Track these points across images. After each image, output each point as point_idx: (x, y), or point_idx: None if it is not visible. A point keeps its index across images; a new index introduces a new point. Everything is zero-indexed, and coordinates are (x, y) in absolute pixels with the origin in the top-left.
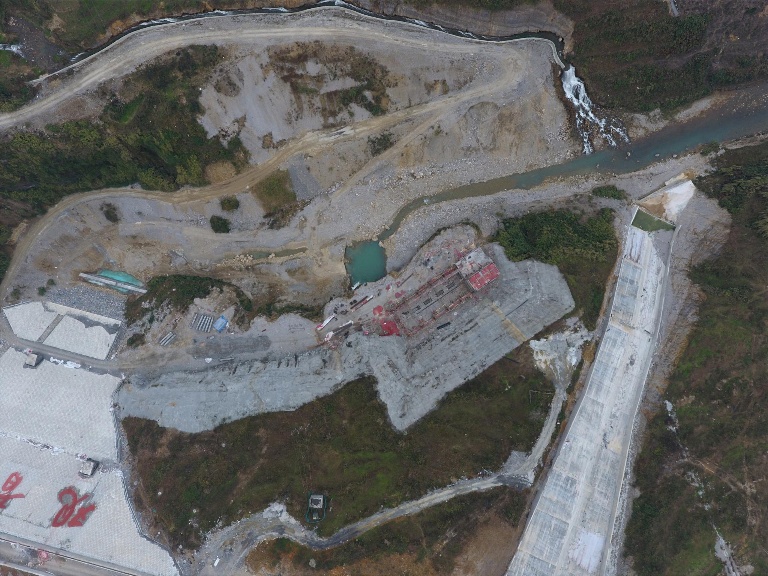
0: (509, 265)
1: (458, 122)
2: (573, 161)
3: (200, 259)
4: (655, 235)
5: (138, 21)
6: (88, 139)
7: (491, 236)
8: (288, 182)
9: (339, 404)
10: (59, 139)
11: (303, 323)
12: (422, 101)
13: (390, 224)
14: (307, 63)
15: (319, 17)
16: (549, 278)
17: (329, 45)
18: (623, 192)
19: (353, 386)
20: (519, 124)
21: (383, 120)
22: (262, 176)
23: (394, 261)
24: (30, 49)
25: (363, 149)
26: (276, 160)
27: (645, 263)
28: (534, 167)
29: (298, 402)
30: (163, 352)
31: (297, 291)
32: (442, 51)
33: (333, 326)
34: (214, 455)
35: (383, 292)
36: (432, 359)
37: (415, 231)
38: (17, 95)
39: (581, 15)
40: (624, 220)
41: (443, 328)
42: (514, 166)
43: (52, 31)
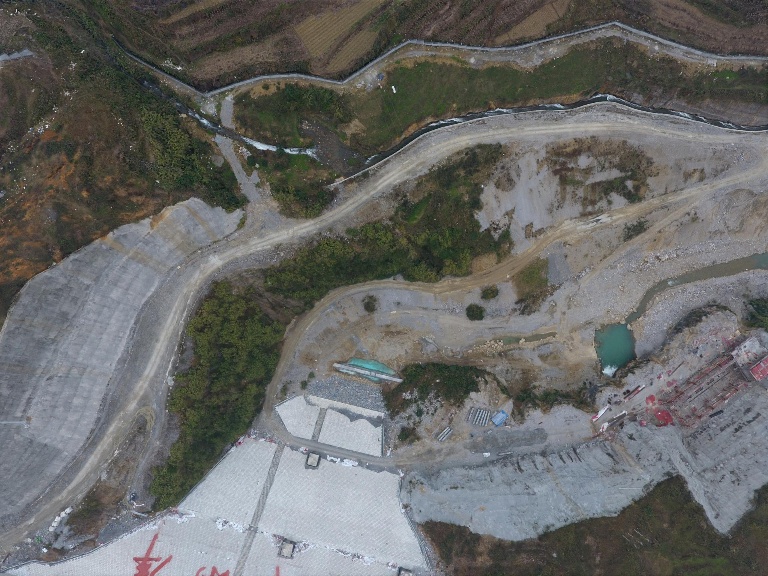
0: None
1: (713, 208)
2: None
3: (451, 346)
4: None
5: (428, 122)
6: (384, 241)
7: (745, 319)
8: (544, 269)
9: (655, 507)
10: (357, 242)
11: (578, 414)
12: (678, 188)
13: (637, 307)
14: (580, 157)
15: (594, 113)
16: None
17: (604, 140)
18: None
19: (665, 487)
20: None
21: (639, 207)
22: (522, 265)
23: (644, 344)
24: (325, 152)
25: (618, 235)
26: (535, 249)
27: None
28: None
29: (616, 506)
30: (440, 447)
31: (550, 376)
32: (706, 142)
33: (608, 417)
34: (547, 566)
35: (655, 381)
36: (720, 452)
37: (663, 314)
38: (313, 199)
39: None
40: None
41: (716, 416)
42: (755, 247)
43: (352, 136)
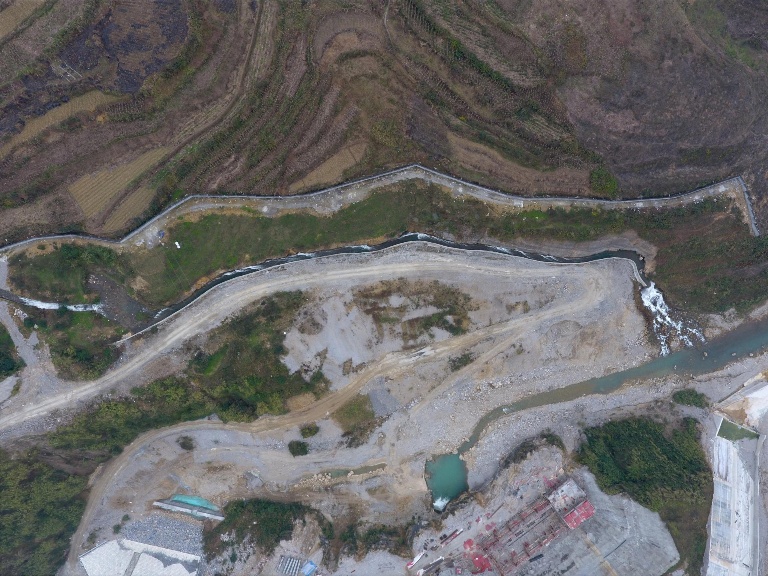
0: (601, 495)
1: (539, 339)
2: (650, 363)
3: (277, 480)
4: (739, 444)
5: (222, 272)
6: (174, 398)
7: (576, 452)
8: (368, 404)
9: None
10: (144, 401)
11: (393, 561)
12: (503, 320)
13: (470, 436)
14: (390, 297)
15: (402, 253)
16: (649, 523)
17: (413, 281)
18: (703, 397)
19: None
20: (601, 339)
21: (463, 339)
22: (342, 401)
23: (476, 476)
24: (112, 307)
25: (443, 368)
26: (356, 384)
27: (734, 480)
28: (612, 371)
29: None
30: None
31: (378, 511)
32: (525, 277)
33: (424, 563)
34: None
35: (473, 525)
36: None
37: (496, 443)
38: (99, 356)
39: (665, 242)
40: (709, 432)
41: (536, 561)
42: (592, 372)
43: (136, 293)
